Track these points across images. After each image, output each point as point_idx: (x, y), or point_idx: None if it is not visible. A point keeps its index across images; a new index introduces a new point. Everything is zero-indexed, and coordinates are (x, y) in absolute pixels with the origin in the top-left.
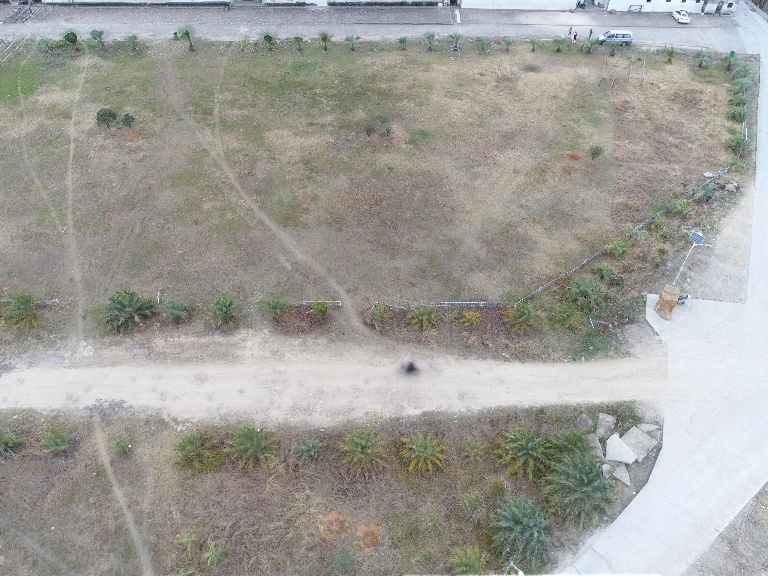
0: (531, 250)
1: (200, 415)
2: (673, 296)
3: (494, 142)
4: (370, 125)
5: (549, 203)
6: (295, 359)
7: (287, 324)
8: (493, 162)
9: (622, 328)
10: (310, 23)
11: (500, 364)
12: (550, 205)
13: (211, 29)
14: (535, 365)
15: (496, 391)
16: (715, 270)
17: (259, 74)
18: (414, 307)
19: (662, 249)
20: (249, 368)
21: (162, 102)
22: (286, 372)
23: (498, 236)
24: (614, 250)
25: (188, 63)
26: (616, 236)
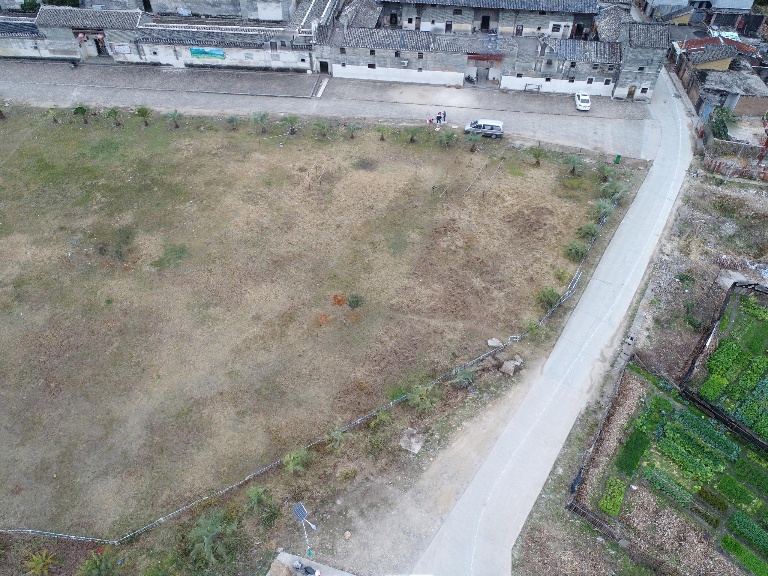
0: (199, 447)
1: None
2: None
3: (257, 270)
4: None
5: (268, 371)
6: None
7: None
8: (237, 301)
9: None
10: (152, 89)
11: None
12: (267, 374)
13: (41, 91)
14: None
15: None
16: (395, 519)
17: (52, 154)
18: None
19: (345, 474)
20: None
21: None
22: None
23: (171, 420)
24: None
25: None
26: (320, 434)
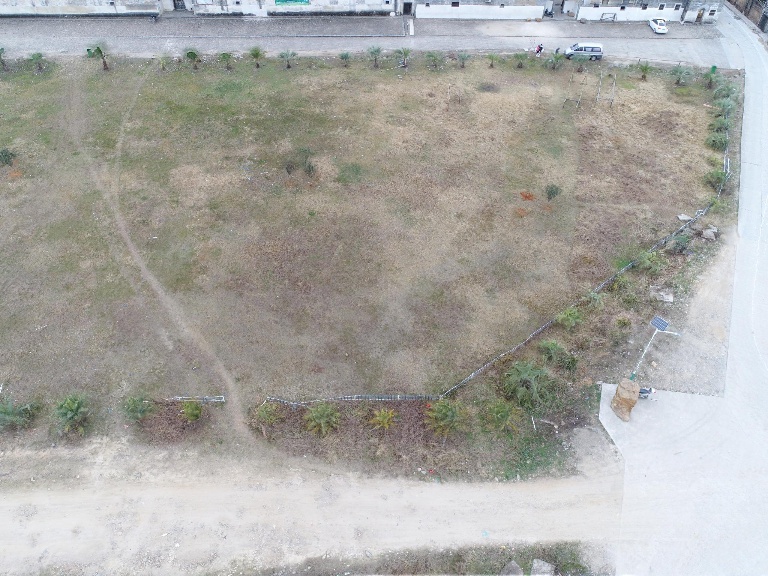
0: (468, 320)
1: (14, 569)
2: (632, 394)
3: (437, 178)
4: (295, 158)
5: (495, 256)
6: (154, 481)
7: (152, 429)
8: (433, 204)
9: (569, 432)
10: (245, 36)
11: (413, 485)
12: (495, 259)
13: (132, 44)
14: (457, 486)
15: (404, 526)
16: (687, 349)
17: (177, 97)
18: (314, 403)
19: (623, 320)
20: (93, 495)
21: (60, 132)
22: (139, 501)
23: (430, 301)
24: (566, 321)
25: (99, 84)
26: (571, 299)
